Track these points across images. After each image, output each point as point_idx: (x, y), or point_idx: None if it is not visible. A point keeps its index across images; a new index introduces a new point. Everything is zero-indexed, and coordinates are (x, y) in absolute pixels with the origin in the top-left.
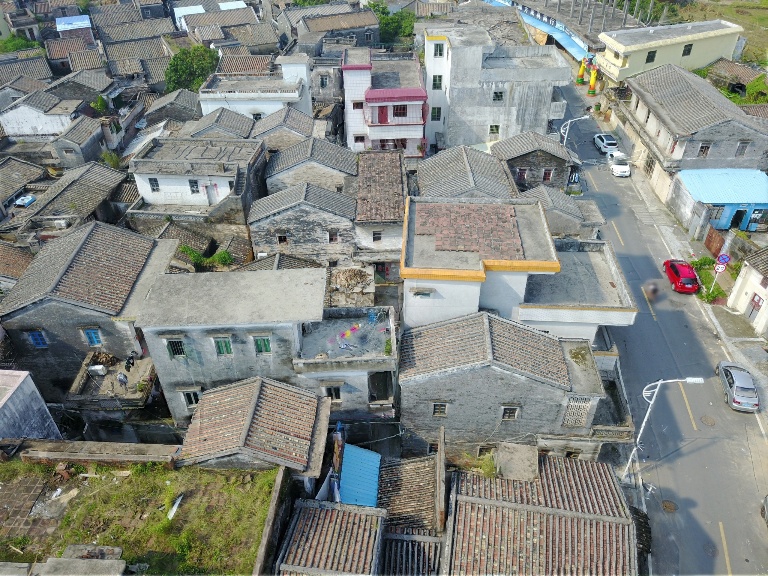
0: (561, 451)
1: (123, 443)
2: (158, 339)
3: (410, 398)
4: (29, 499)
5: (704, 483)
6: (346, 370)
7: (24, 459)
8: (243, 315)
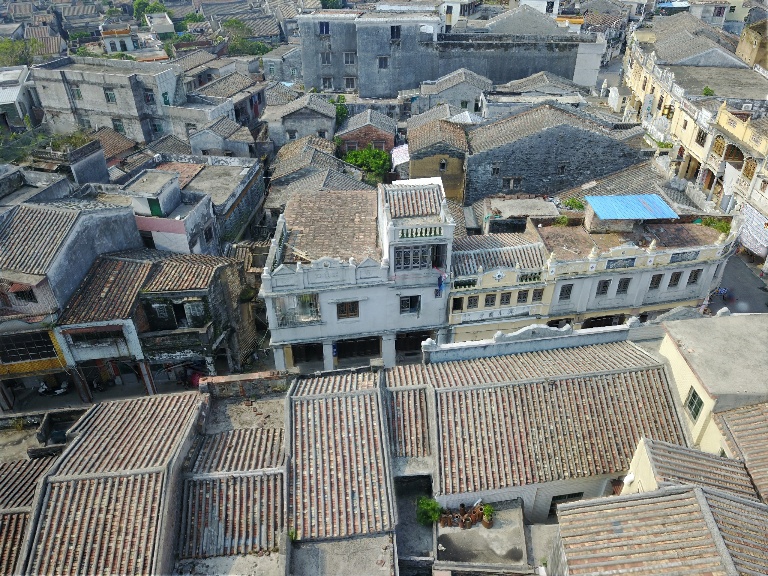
0: None
1: None
2: None
3: None
4: None
5: None
6: None
7: (497, 0)
8: None
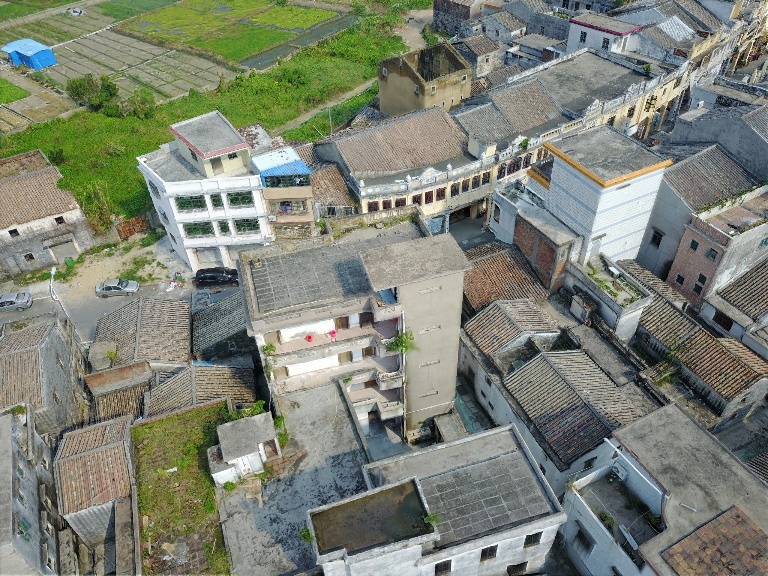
0: (76, 360)
1: (116, 546)
2: (16, 539)
3: (51, 410)
4: (176, 572)
5: (87, 318)
6: (34, 434)
7: None
8: (2, 465)
